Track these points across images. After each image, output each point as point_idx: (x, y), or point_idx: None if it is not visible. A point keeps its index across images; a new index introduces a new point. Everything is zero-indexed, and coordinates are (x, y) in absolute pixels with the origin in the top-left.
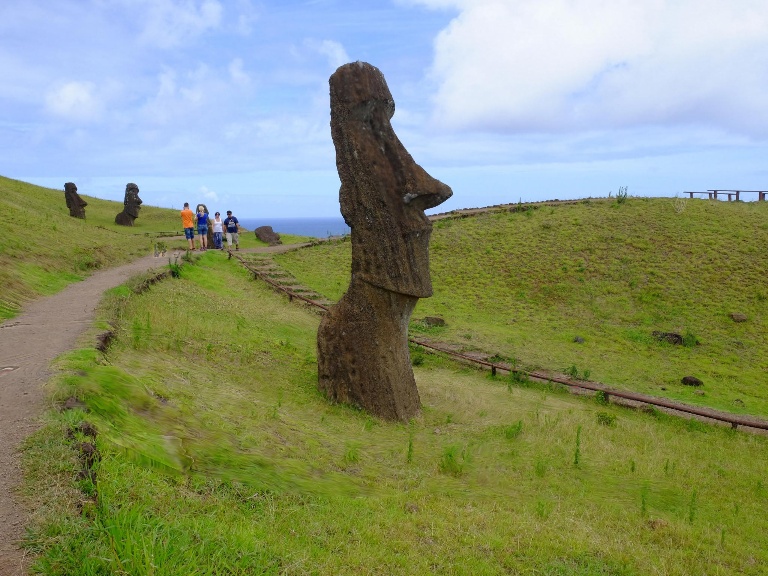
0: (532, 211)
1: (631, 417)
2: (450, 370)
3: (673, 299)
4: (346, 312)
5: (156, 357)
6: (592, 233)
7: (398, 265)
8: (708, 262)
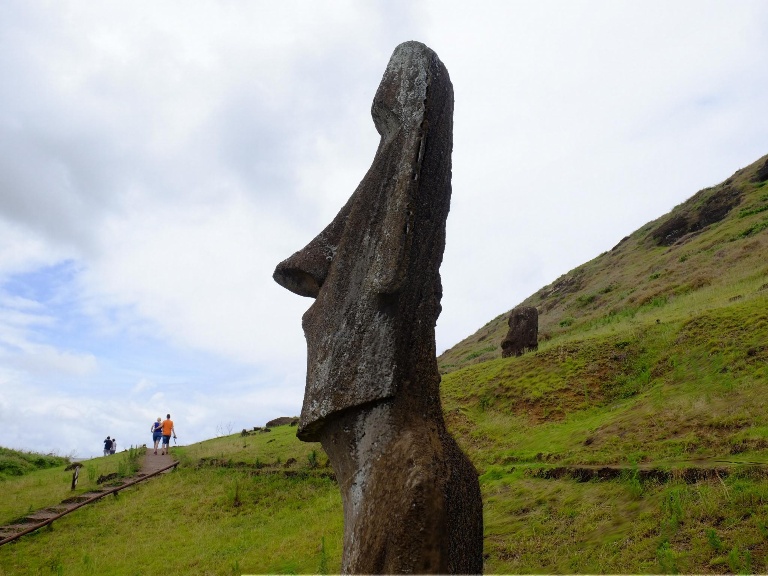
0: None
1: None
2: None
3: None
4: None
5: (625, 505)
6: None
7: None
8: None
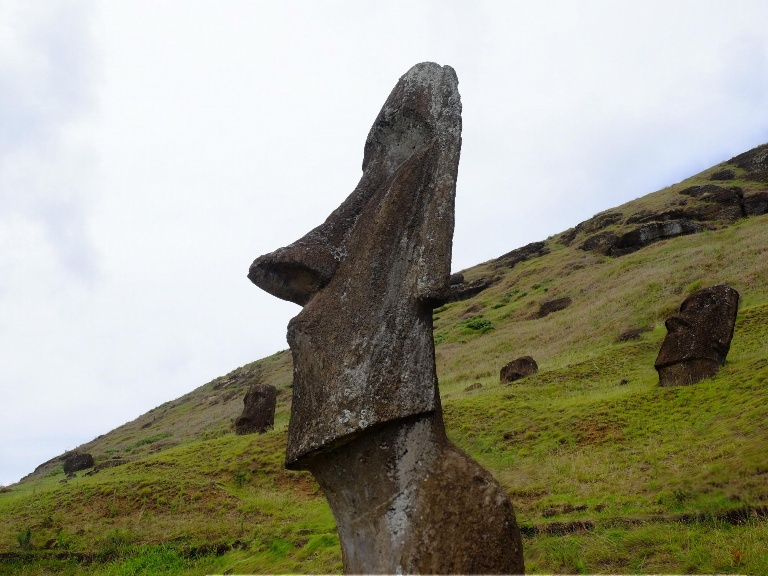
0: None
1: None
2: None
3: None
4: None
5: None
6: None
7: None
8: None
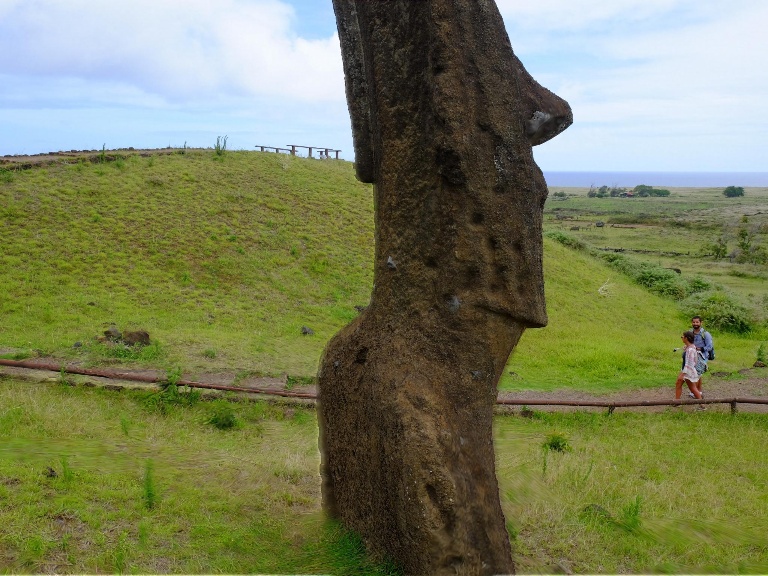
0: (122, 162)
1: (548, 430)
2: (277, 421)
3: (342, 266)
4: (447, 388)
5: None
6: (216, 191)
7: (539, 267)
8: (348, 223)
